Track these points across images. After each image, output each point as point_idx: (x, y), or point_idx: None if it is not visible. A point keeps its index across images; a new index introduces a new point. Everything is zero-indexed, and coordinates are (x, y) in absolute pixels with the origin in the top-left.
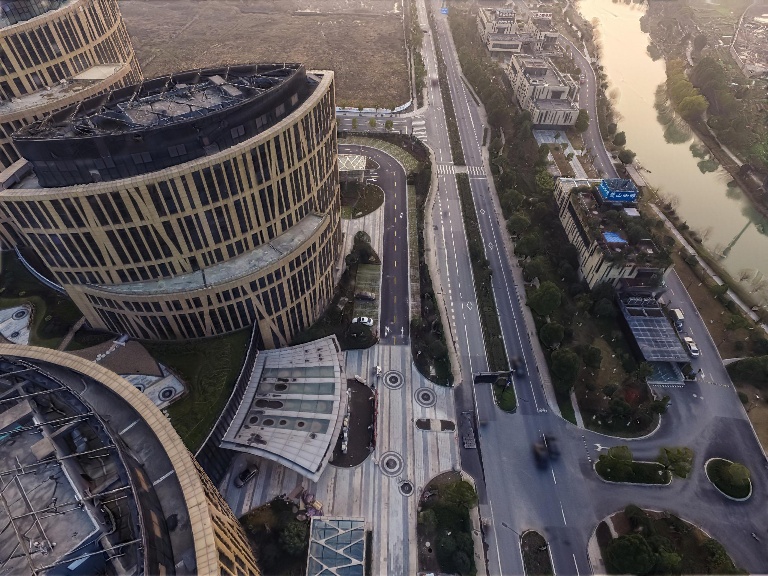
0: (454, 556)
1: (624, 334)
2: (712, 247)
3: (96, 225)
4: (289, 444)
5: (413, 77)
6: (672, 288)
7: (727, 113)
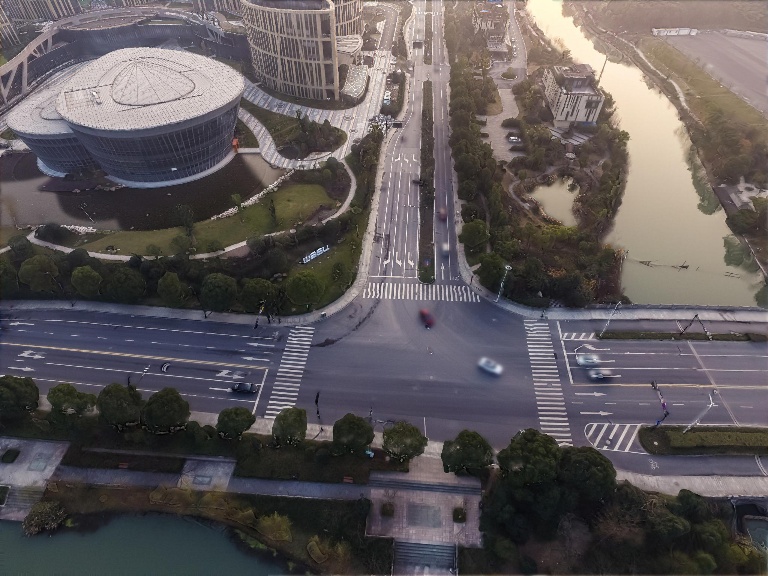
0: None
1: None
2: (548, 36)
3: None
4: None
5: None
6: None
7: None
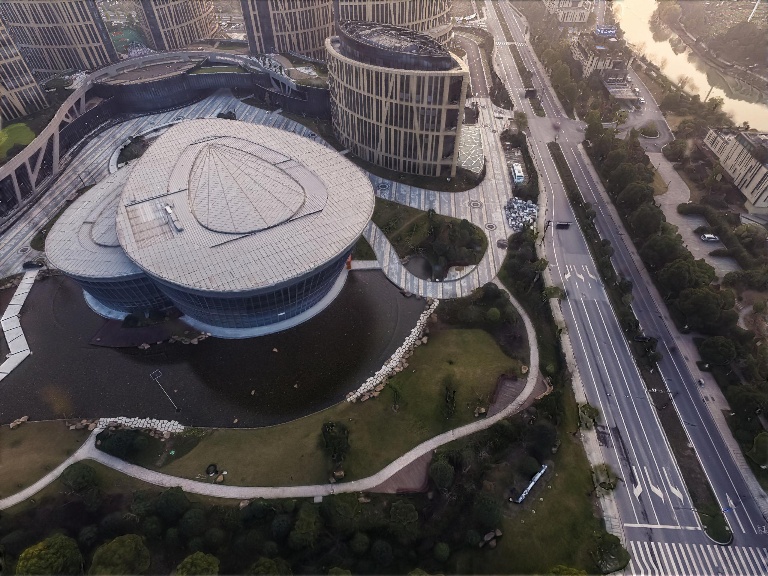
0: (518, 138)
1: (605, 96)
2: (666, 72)
3: (370, 1)
4: None
5: (475, 4)
6: (636, 84)
7: (695, 16)
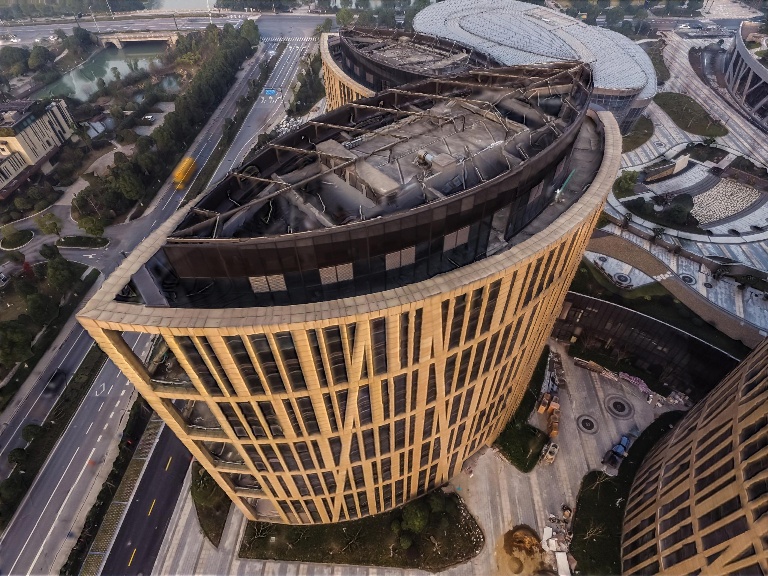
0: None
1: None
2: None
3: None
4: None
5: None
6: None
7: None
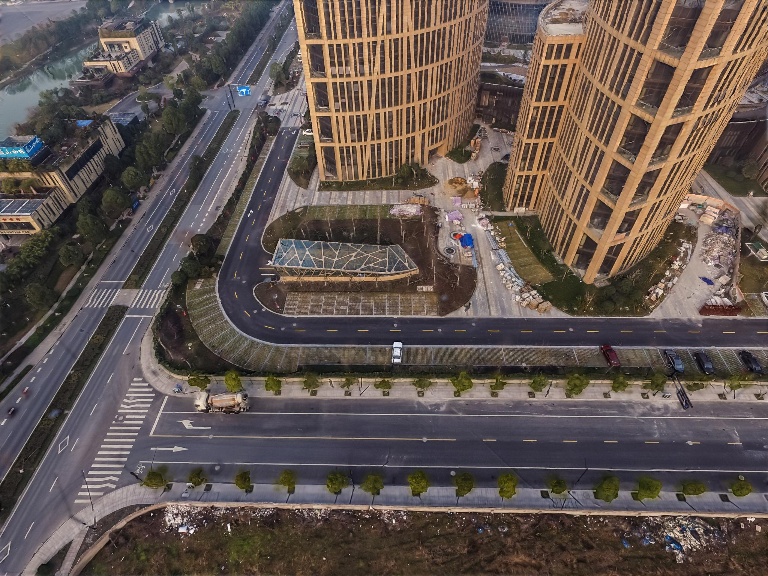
0: None
1: None
2: None
3: None
4: None
5: None
6: None
7: None
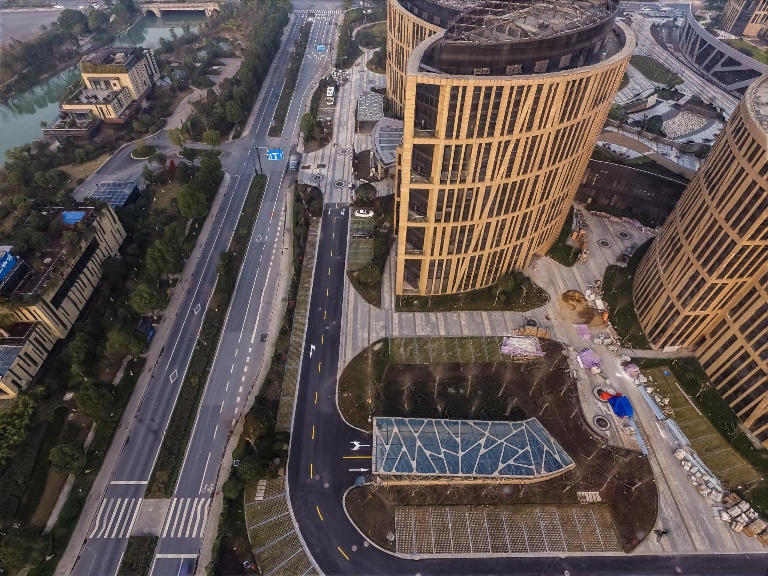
0: None
1: None
2: None
3: None
4: (401, 124)
5: None
6: None
7: None
